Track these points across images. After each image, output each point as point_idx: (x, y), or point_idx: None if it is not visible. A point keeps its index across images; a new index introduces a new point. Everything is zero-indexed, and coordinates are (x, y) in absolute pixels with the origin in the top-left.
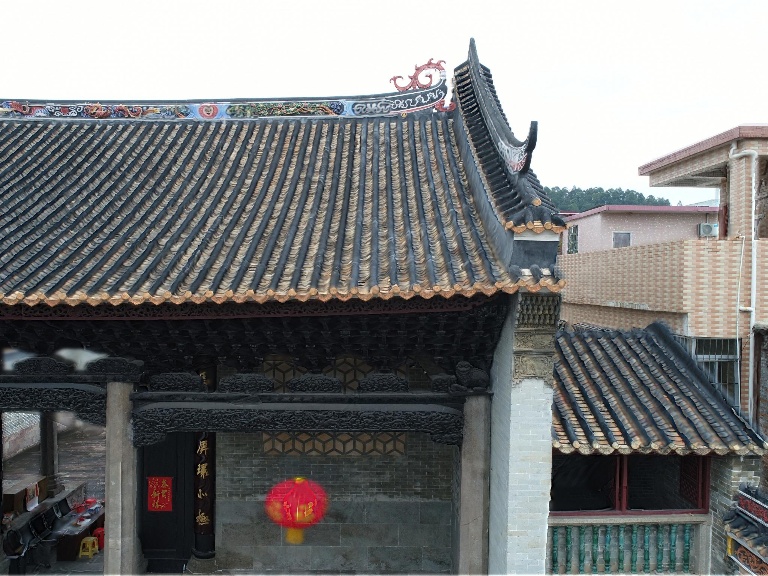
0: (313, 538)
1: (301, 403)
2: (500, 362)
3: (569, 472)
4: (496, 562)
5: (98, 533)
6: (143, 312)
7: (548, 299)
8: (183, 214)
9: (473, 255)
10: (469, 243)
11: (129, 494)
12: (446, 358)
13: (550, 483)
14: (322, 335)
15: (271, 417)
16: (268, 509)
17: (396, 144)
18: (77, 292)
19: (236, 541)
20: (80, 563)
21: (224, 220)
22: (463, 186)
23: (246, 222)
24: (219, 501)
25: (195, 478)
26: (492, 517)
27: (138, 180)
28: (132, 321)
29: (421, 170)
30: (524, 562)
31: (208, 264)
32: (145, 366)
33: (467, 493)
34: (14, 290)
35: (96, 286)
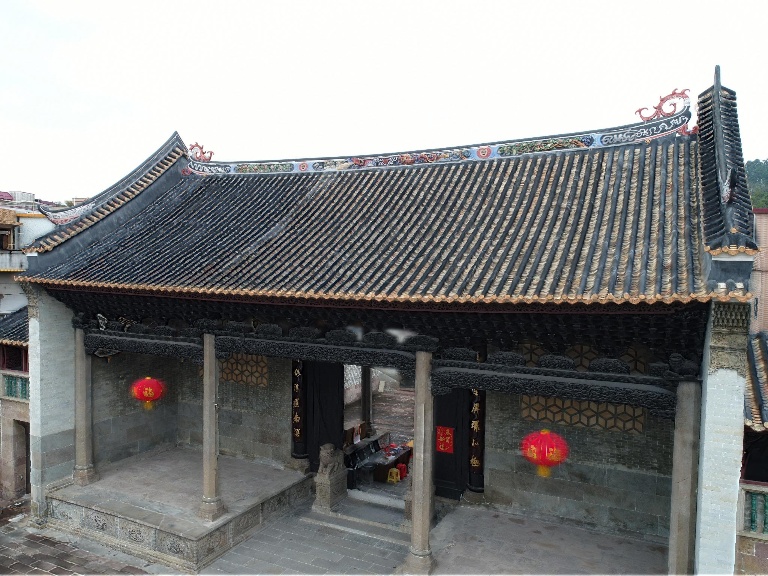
0: (561, 491)
1: (545, 375)
2: (705, 355)
3: (765, 449)
4: (698, 513)
5: (400, 467)
6: (440, 307)
7: (739, 307)
8: (465, 238)
9: (683, 270)
10: (683, 260)
11: (429, 426)
12: (661, 350)
13: (742, 453)
14: (559, 327)
15: (523, 383)
16: (525, 462)
17: (637, 170)
18: (403, 293)
19: (499, 483)
20: (388, 485)
21: (493, 242)
22: (692, 207)
23: (508, 244)
24: (487, 450)
25: (470, 431)
26: (698, 479)
27: (435, 212)
28: (433, 312)
29: (656, 193)
30: (717, 511)
31: (481, 276)
32: (440, 342)
33: (678, 458)
34: (369, 291)
35: (413, 290)
